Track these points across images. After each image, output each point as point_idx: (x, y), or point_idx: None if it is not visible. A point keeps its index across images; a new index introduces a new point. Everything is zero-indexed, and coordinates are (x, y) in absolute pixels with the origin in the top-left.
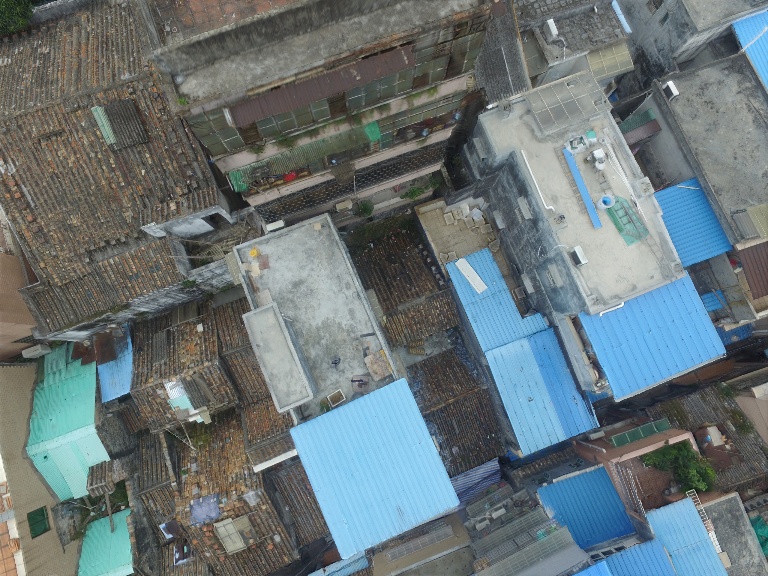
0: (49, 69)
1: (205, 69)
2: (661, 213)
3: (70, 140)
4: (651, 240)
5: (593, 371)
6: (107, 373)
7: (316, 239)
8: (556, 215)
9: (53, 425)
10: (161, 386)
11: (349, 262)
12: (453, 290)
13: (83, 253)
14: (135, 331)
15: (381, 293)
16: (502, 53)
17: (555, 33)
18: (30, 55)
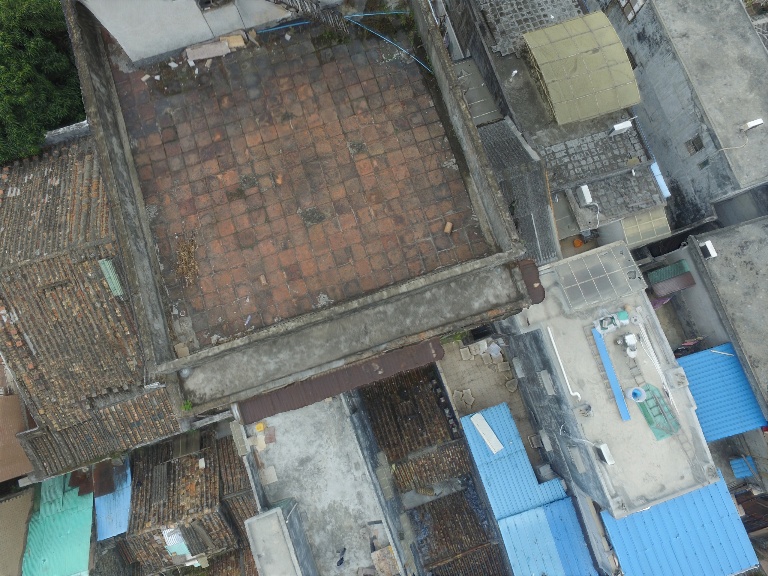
0: (58, 207)
1: (214, 362)
2: (695, 407)
3: (75, 290)
4: (683, 436)
5: (613, 558)
6: (104, 507)
7: (326, 411)
8: (582, 406)
9: (46, 567)
10: (158, 532)
11: (360, 448)
12: (467, 442)
13: (84, 400)
14: (135, 460)
15: (391, 435)
16: (532, 219)
17: (589, 201)
18: (40, 186)
